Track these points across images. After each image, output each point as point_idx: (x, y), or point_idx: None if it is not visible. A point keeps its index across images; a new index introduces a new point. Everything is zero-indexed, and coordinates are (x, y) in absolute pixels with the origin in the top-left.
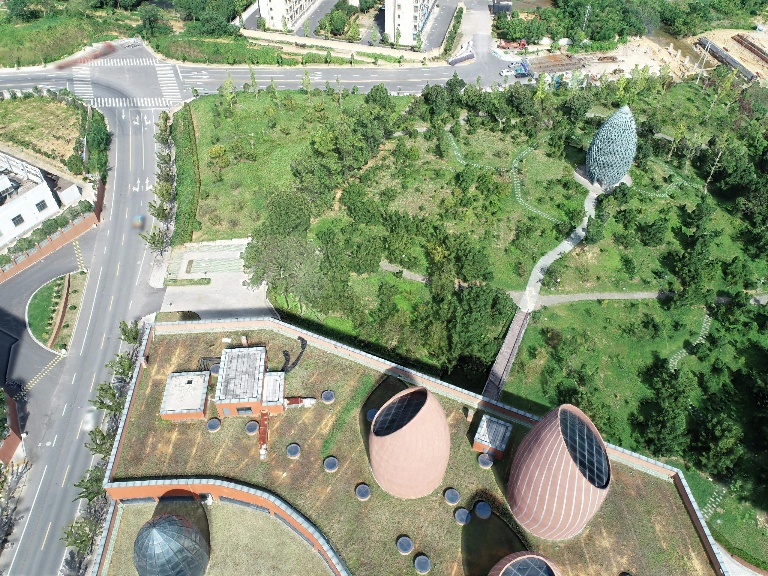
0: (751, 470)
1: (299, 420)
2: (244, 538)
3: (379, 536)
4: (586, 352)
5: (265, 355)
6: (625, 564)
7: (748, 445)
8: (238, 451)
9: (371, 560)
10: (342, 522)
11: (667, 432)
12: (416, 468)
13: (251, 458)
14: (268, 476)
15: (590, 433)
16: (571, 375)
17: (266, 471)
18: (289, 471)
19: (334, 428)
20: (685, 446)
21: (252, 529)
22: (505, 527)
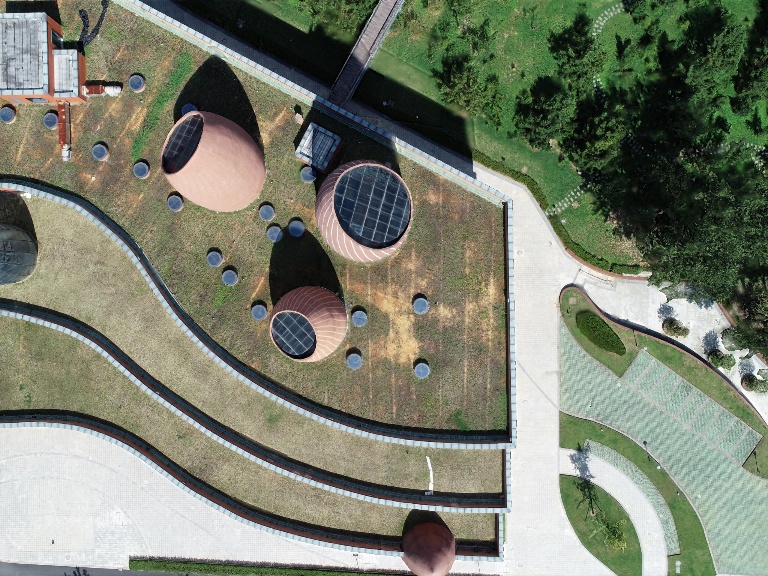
0: (628, 164)
1: (105, 112)
2: (68, 233)
3: (191, 248)
4: (496, 0)
5: (48, 24)
6: (423, 286)
7: (639, 136)
8: (40, 148)
9: (183, 270)
10: (155, 232)
11: (546, 125)
12: (209, 202)
13: (56, 157)
14: (76, 179)
15: (395, 182)
16: (465, 36)
17: (73, 173)
18: (98, 175)
19: (145, 125)
20: (567, 136)
21: (75, 225)
22: (316, 246)
